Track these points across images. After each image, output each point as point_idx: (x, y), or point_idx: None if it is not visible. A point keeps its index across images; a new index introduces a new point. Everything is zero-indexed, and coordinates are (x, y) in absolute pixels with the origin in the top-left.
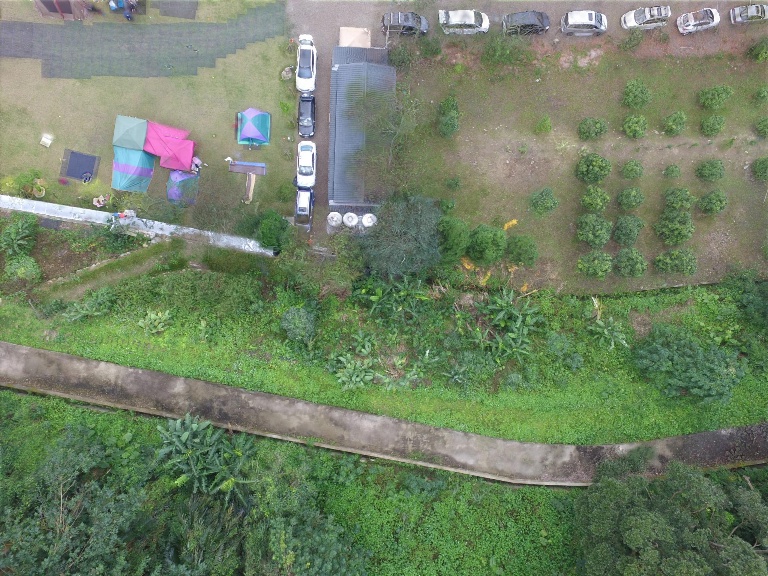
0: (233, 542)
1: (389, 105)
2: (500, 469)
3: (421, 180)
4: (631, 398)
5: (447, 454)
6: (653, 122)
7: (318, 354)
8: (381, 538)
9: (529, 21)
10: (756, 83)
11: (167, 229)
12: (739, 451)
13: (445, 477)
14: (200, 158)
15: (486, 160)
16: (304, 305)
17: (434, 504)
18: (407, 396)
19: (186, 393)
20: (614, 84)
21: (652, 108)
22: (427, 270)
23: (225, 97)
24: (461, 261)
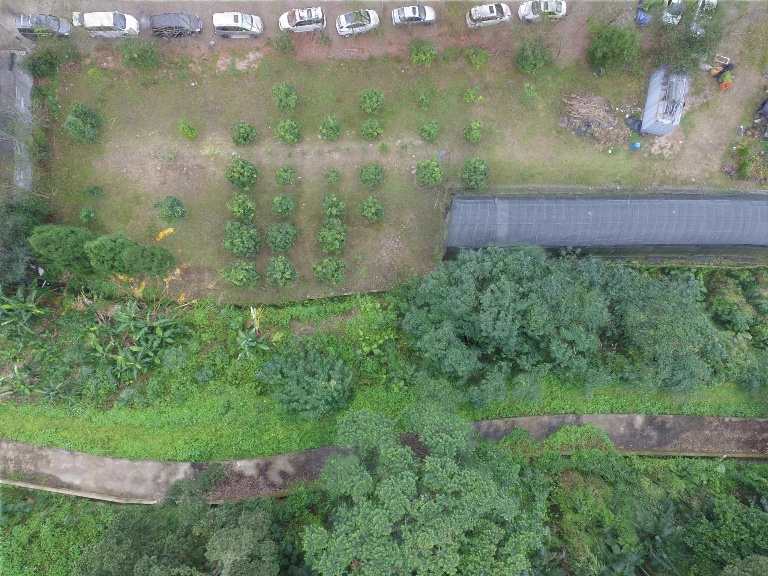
0: None
1: None
2: (109, 488)
3: (70, 188)
4: (252, 412)
5: (51, 474)
6: (317, 126)
7: None
8: None
9: (171, 23)
10: (424, 86)
11: None
12: (365, 465)
13: (46, 498)
14: None
15: (135, 167)
16: None
17: (14, 527)
18: (11, 414)
19: None
20: None
21: (315, 112)
22: (77, 281)
23: None
24: None
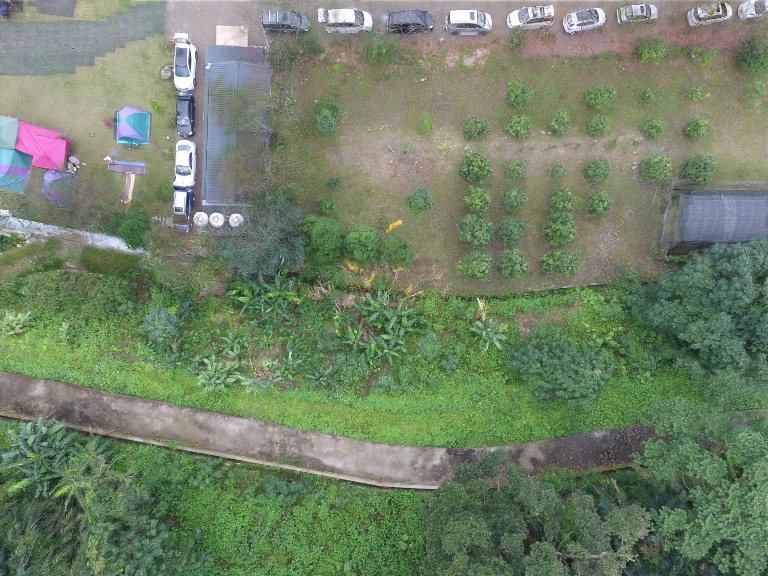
0: (65, 548)
1: (259, 104)
2: (369, 472)
3: (304, 180)
4: (503, 400)
5: (315, 457)
6: (540, 122)
7: (184, 356)
8: (234, 543)
9: (410, 20)
10: (644, 83)
11: (44, 229)
12: (613, 454)
13: (311, 481)
14: (78, 157)
15: (369, 160)
16: (179, 306)
17: (294, 508)
18: (275, 398)
19: (46, 396)
20: (501, 84)
21: (539, 108)
22: (310, 271)
23: (104, 96)
24: (343, 262)
